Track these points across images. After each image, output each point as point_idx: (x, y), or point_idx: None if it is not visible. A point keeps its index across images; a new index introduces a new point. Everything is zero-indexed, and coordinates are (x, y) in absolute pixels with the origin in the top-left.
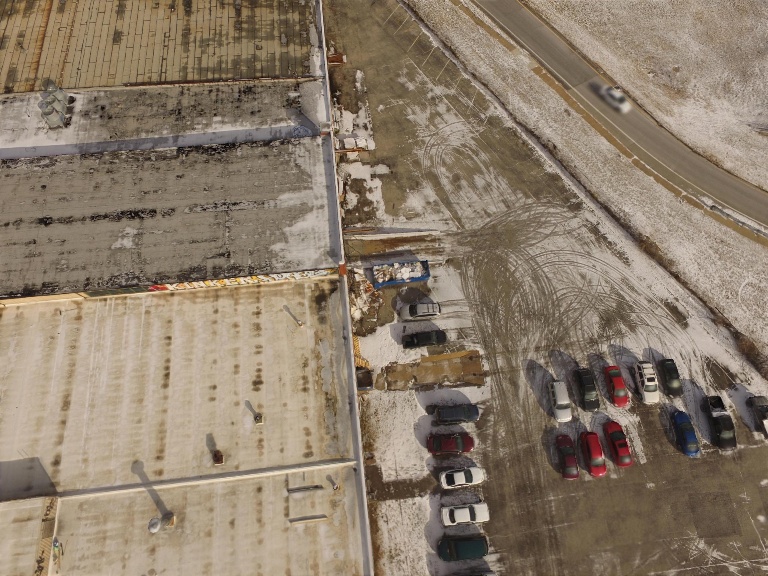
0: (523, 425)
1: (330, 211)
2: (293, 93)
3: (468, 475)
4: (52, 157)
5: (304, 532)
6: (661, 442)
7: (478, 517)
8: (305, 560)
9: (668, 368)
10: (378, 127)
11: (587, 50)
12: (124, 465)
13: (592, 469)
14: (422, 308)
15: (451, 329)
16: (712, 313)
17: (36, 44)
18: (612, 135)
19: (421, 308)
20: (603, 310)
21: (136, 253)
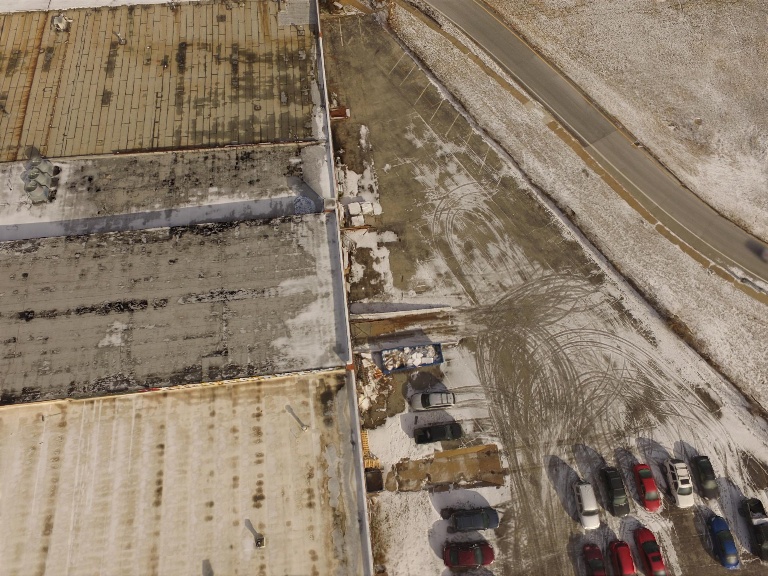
0: (547, 532)
1: (336, 300)
2: (294, 159)
3: None
4: (35, 240)
5: None
6: (697, 551)
7: None
8: None
9: (703, 467)
10: (384, 189)
11: (604, 102)
12: None
13: None
14: (435, 399)
15: (466, 420)
16: (747, 401)
17: (19, 107)
18: (634, 198)
19: (434, 399)
20: (630, 398)
21: (125, 352)
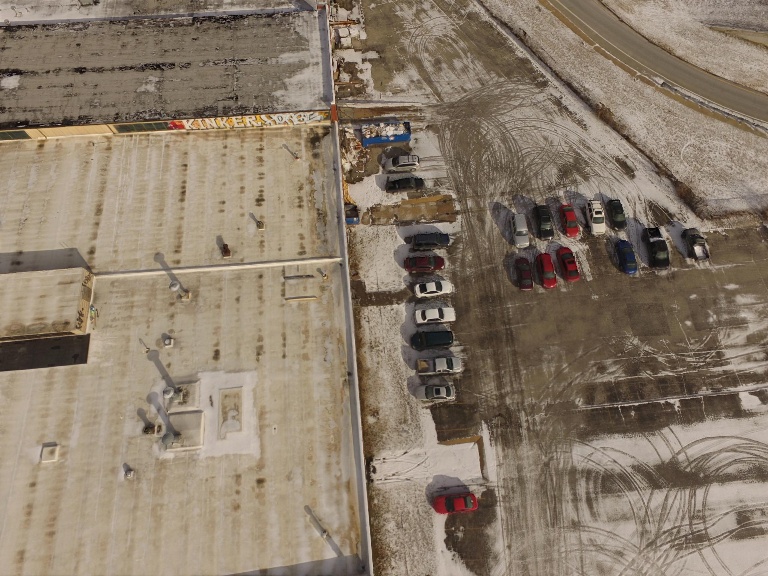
0: (488, 251)
1: (324, 67)
2: None
3: (438, 285)
4: (85, 23)
5: (297, 308)
6: (606, 265)
7: (446, 316)
8: (298, 327)
9: (614, 206)
10: (369, 21)
11: None
12: (148, 256)
13: (544, 281)
14: (403, 159)
15: (428, 179)
16: (657, 167)
17: None
18: (577, 27)
19: (402, 159)
20: (561, 164)
21: (158, 95)
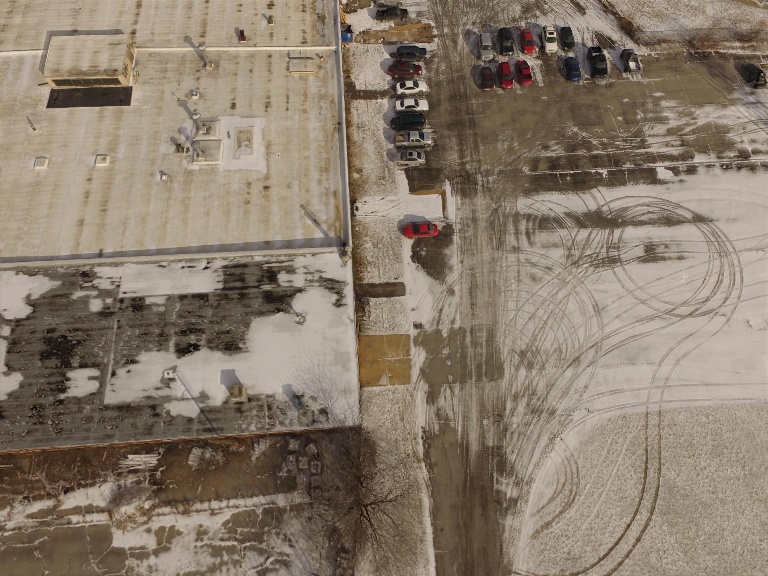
0: (458, 63)
1: None
2: None
3: (416, 84)
4: None
5: (299, 78)
6: (555, 75)
7: (420, 105)
8: (299, 91)
9: (565, 30)
10: None
11: None
12: (179, 38)
13: (503, 82)
14: None
15: (412, 12)
16: (604, 7)
17: None
18: None
19: None
20: (525, 3)
21: None
